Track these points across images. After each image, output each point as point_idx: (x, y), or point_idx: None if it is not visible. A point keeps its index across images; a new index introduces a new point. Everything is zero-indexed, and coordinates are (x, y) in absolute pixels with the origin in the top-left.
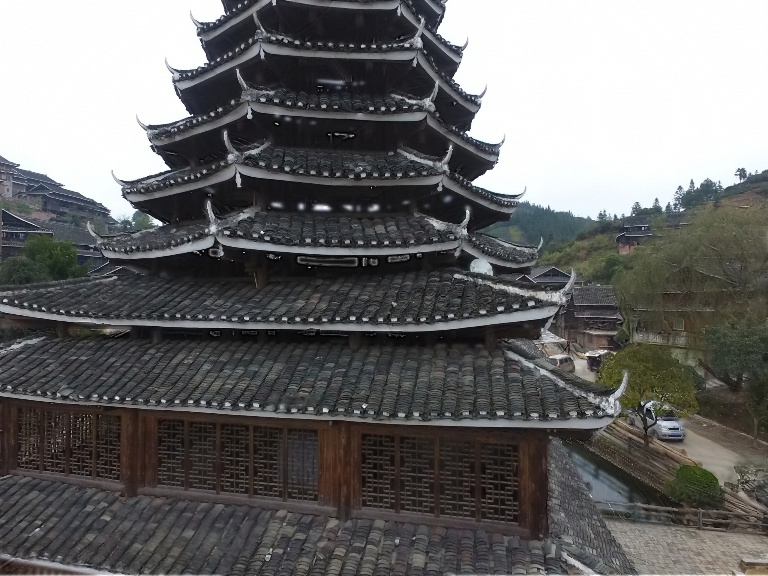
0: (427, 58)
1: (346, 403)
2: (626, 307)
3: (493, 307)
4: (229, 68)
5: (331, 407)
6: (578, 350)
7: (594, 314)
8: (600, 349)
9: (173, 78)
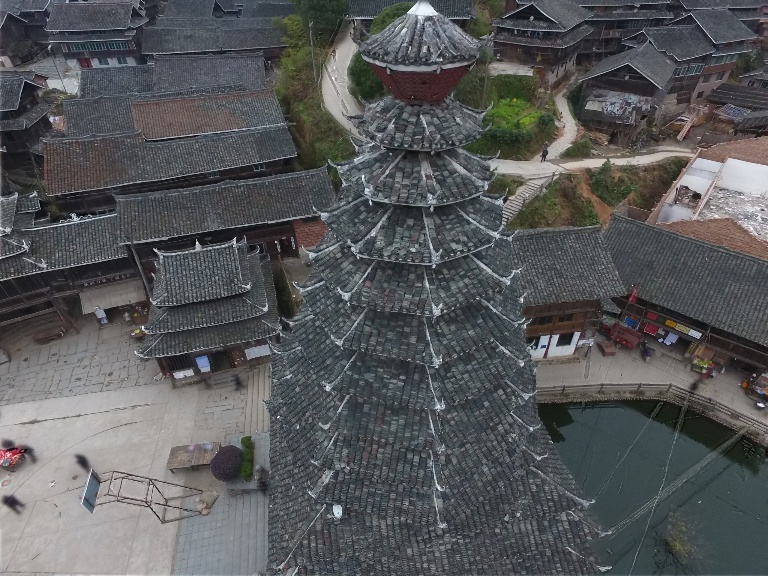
0: (340, 393)
1: (271, 498)
2: None
3: (280, 536)
4: None
5: (270, 494)
6: None
7: None
8: None
9: None
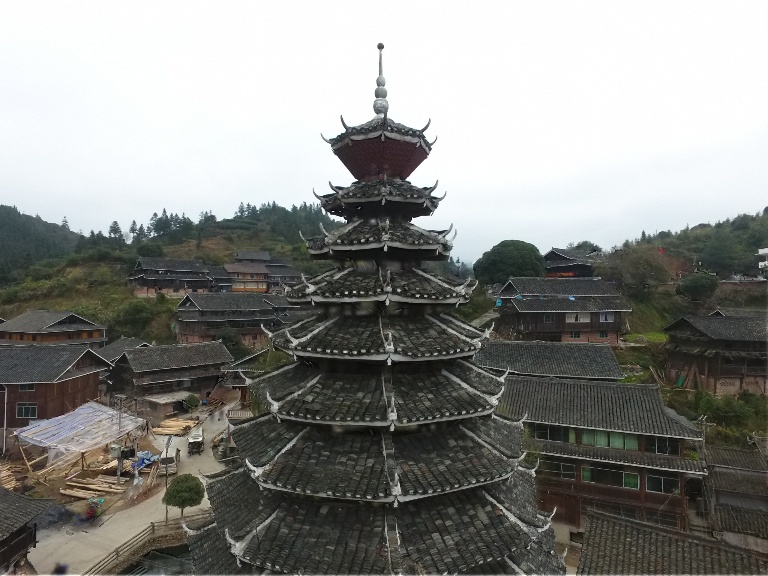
0: None
1: None
2: (260, 406)
3: None
4: (476, 486)
5: None
6: (153, 426)
7: (154, 379)
8: (167, 417)
9: (401, 493)
